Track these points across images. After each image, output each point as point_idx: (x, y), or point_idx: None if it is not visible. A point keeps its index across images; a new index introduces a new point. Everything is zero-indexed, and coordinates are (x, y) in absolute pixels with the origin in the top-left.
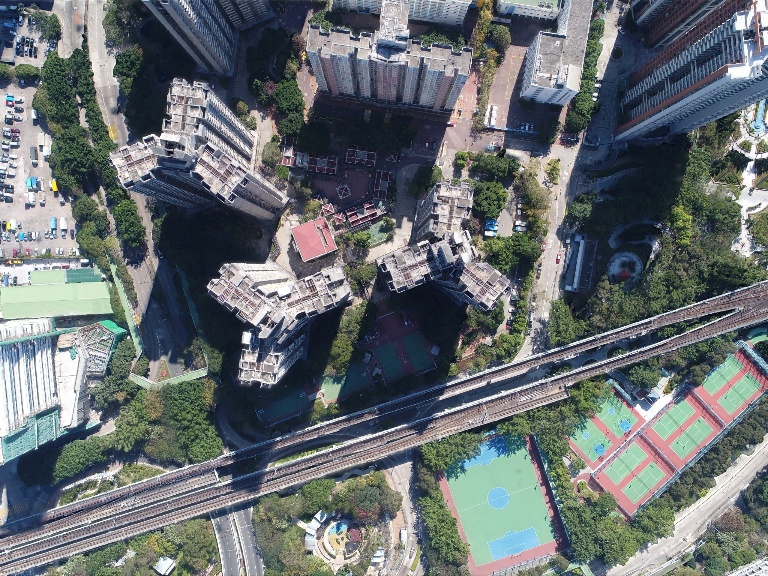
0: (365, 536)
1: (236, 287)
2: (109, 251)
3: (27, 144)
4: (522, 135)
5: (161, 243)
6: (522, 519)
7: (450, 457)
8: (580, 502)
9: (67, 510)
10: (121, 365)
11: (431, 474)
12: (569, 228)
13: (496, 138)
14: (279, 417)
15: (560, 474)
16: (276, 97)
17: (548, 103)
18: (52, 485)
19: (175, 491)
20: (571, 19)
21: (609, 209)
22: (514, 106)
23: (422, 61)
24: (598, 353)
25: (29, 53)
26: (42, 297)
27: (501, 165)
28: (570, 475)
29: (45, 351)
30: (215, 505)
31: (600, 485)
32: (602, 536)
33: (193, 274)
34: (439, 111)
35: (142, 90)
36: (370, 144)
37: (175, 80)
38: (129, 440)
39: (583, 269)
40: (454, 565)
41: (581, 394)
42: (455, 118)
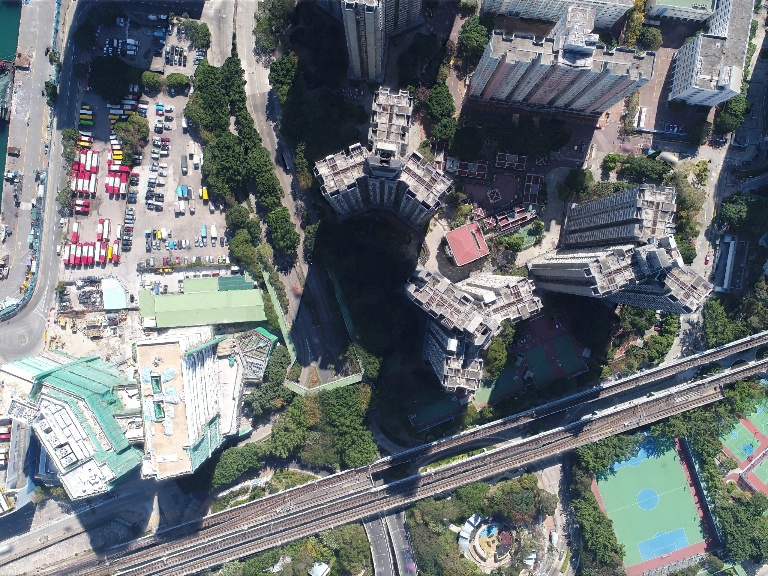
0: (516, 539)
1: (441, 294)
2: (263, 258)
3: (176, 153)
4: (671, 137)
5: (315, 250)
6: (671, 520)
7: (607, 459)
8: (729, 502)
9: (222, 517)
10: (278, 372)
11: (588, 476)
12: (718, 229)
13: (644, 140)
14: (430, 421)
15: (714, 474)
16: (429, 102)
17: (697, 104)
18: (210, 492)
19: (330, 496)
20: (732, 20)
21: (762, 210)
22: (662, 108)
23: (605, 65)
24: (747, 353)
25: (178, 62)
26: (196, 305)
27: (656, 167)
28: (721, 475)
29: (210, 359)
30: (370, 510)
31: (749, 485)
32: (760, 536)
33: (347, 280)
34: (588, 114)
35: (299, 97)
36: (522, 148)
37: (380, 89)
38: (288, 446)
39: (734, 270)
40: (610, 566)
41: (737, 395)
42: (603, 121)
